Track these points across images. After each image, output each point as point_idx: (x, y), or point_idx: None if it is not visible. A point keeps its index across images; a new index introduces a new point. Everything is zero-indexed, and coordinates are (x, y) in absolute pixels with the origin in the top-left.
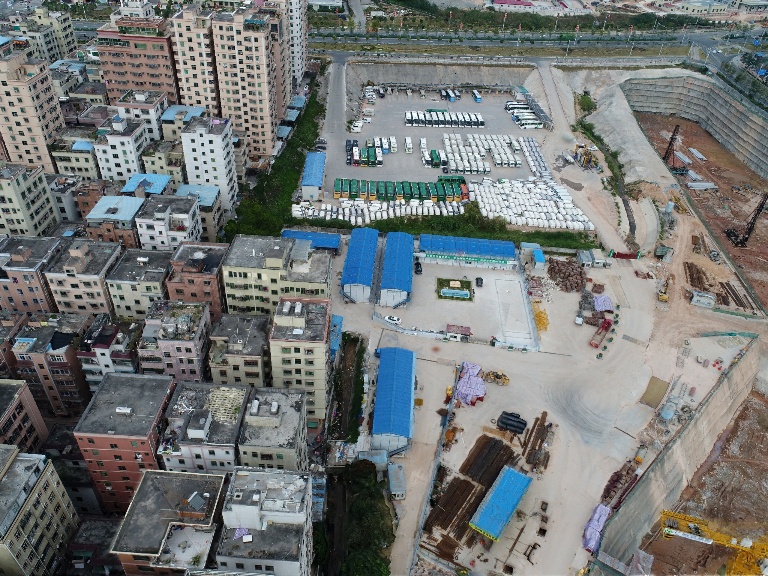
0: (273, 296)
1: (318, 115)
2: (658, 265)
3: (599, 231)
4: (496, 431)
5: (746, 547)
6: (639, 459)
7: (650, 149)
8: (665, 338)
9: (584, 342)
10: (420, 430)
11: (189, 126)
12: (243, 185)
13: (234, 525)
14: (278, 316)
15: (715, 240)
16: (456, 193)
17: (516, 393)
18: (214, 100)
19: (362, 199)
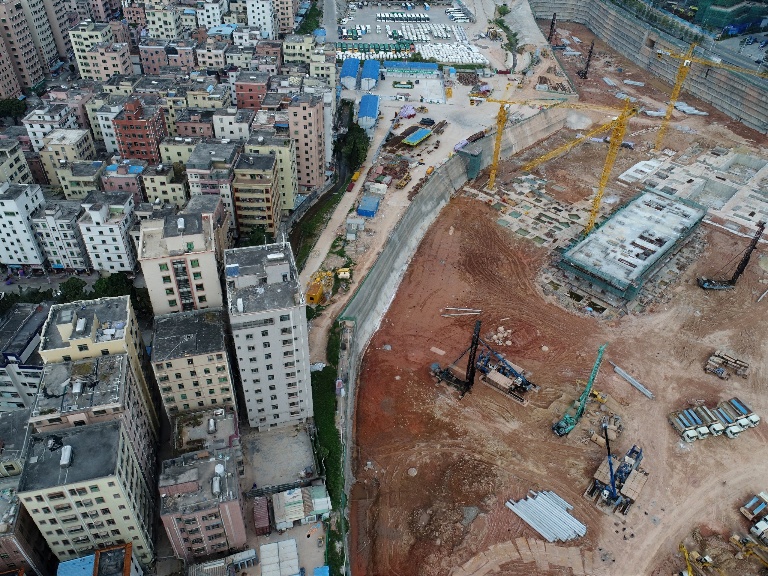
0: (307, 60)
1: (318, 16)
2: None
3: (491, 63)
4: (419, 125)
5: (498, 101)
6: (486, 130)
7: (538, 30)
8: (516, 100)
9: None
10: (382, 125)
11: None
12: None
13: None
14: (313, 55)
15: None
16: (407, 48)
17: (431, 115)
18: None
19: (349, 51)
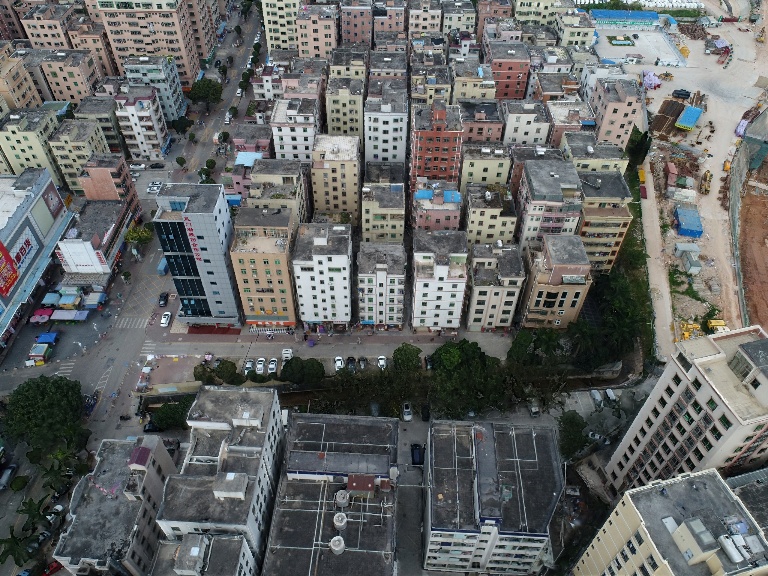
0: (543, 20)
1: None
2: (753, 25)
3: (708, 8)
4: (673, 99)
5: None
6: (760, 105)
7: None
8: (765, 59)
9: (713, 62)
10: None
11: None
12: None
13: (592, 85)
14: (566, 16)
15: None
16: None
17: (678, 84)
18: None
19: None
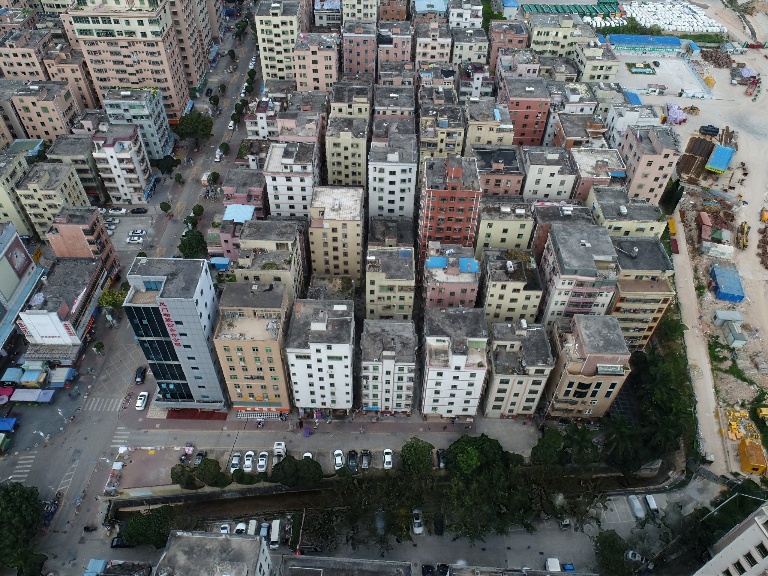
0: (561, 50)
1: None
2: None
3: (732, 32)
4: (700, 135)
5: None
6: None
7: None
8: None
9: (741, 93)
10: None
11: None
12: None
13: (620, 129)
14: (587, 48)
15: None
16: (617, 11)
17: (705, 118)
18: None
19: None
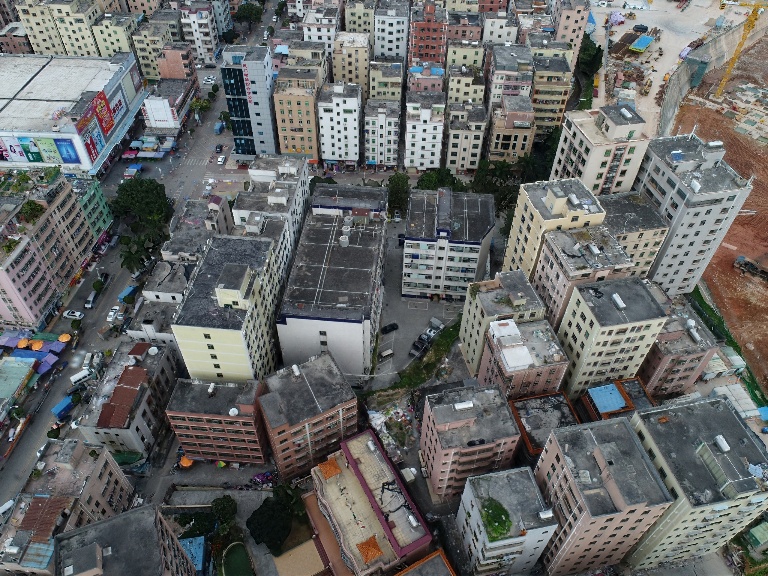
0: None
1: None
2: None
3: None
4: (633, 32)
5: (752, 5)
6: (704, 37)
7: None
8: (718, 6)
9: (673, 7)
10: (595, 32)
11: None
12: None
13: None
14: None
15: None
16: None
17: (640, 22)
18: None
19: None
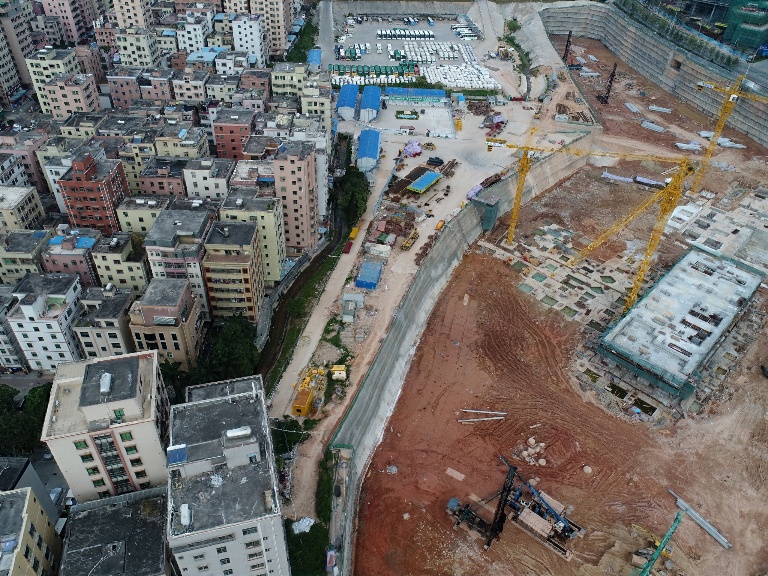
0: (299, 92)
1: (313, 33)
2: None
3: (504, 89)
4: (426, 165)
5: (520, 147)
6: (503, 172)
7: (552, 49)
8: None
9: (483, 135)
10: (384, 166)
11: (235, 19)
12: (268, 64)
13: None
14: (305, 88)
15: (581, 94)
16: (410, 71)
17: (439, 153)
18: (246, 9)
19: (347, 75)
